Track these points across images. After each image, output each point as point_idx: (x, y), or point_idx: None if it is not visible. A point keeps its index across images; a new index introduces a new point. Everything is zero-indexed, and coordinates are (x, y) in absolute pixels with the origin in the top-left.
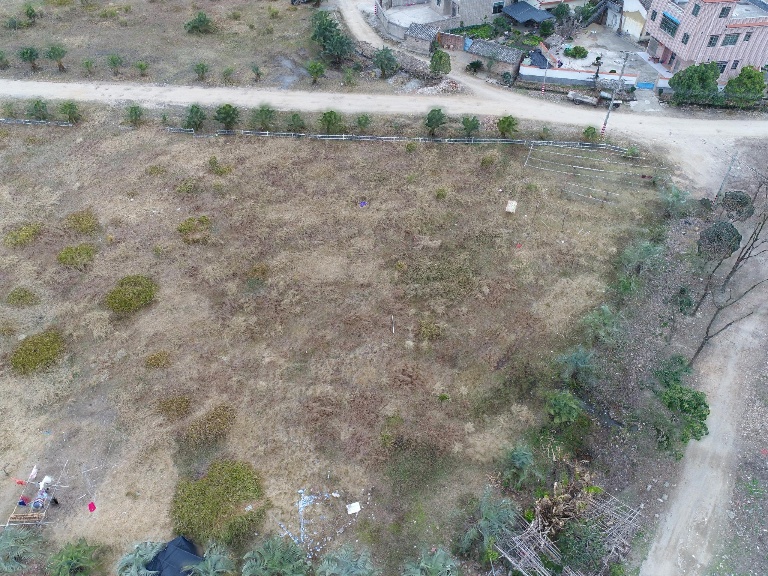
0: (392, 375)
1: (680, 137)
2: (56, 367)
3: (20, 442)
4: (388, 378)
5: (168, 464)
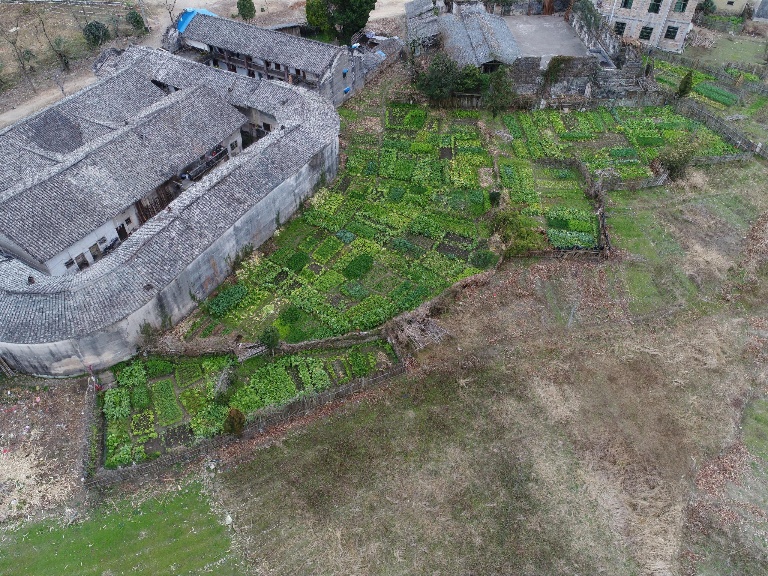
0: None
1: (182, 0)
2: None
3: None
4: None
5: None
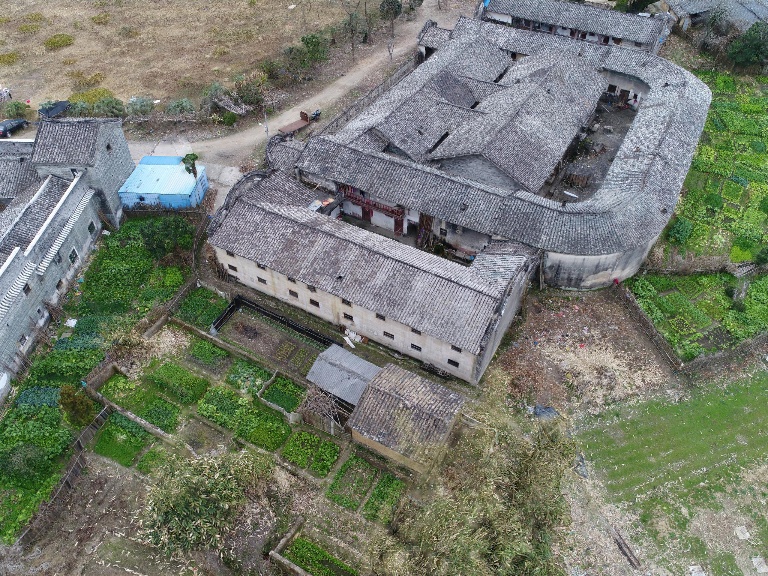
0: None
1: None
2: (15, 64)
3: None
4: (191, 67)
5: (68, 90)
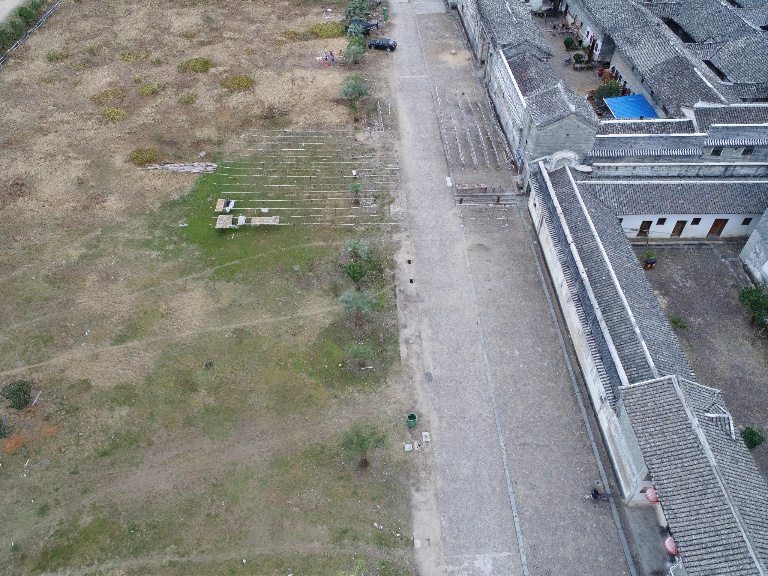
0: (267, 5)
1: None
2: None
3: (298, 76)
4: None
5: None
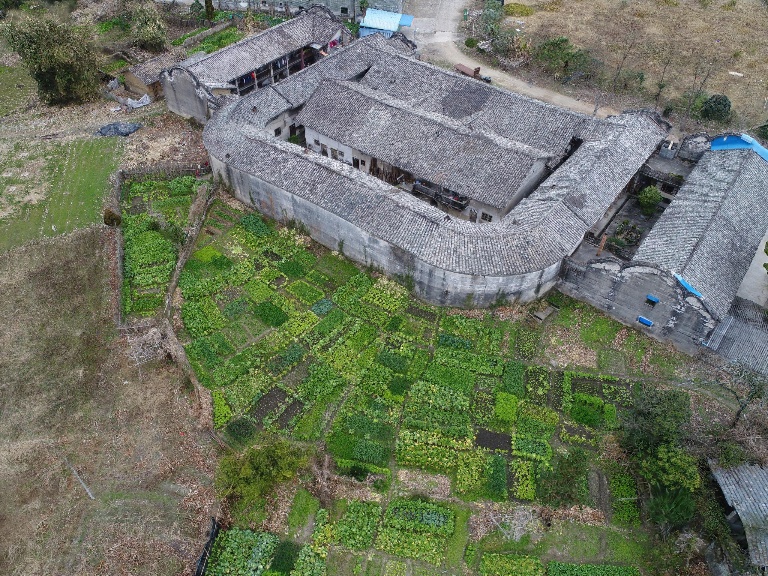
0: None
1: None
2: None
3: None
4: None
5: None
